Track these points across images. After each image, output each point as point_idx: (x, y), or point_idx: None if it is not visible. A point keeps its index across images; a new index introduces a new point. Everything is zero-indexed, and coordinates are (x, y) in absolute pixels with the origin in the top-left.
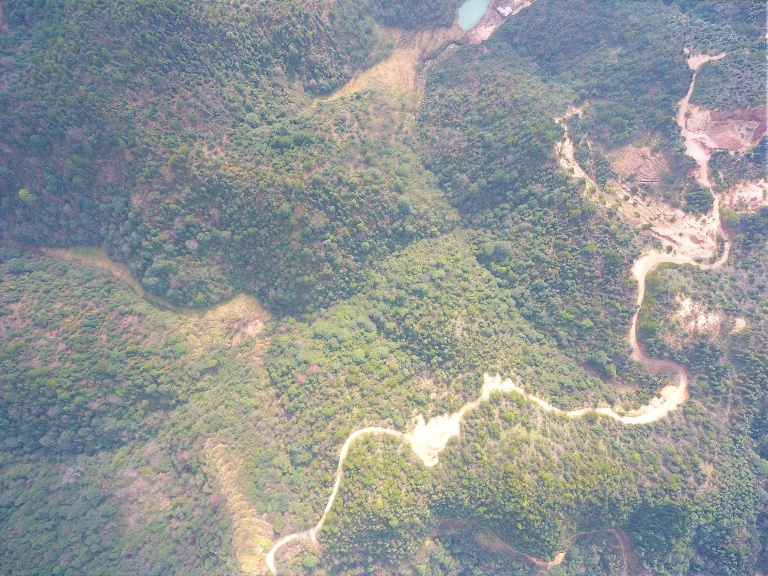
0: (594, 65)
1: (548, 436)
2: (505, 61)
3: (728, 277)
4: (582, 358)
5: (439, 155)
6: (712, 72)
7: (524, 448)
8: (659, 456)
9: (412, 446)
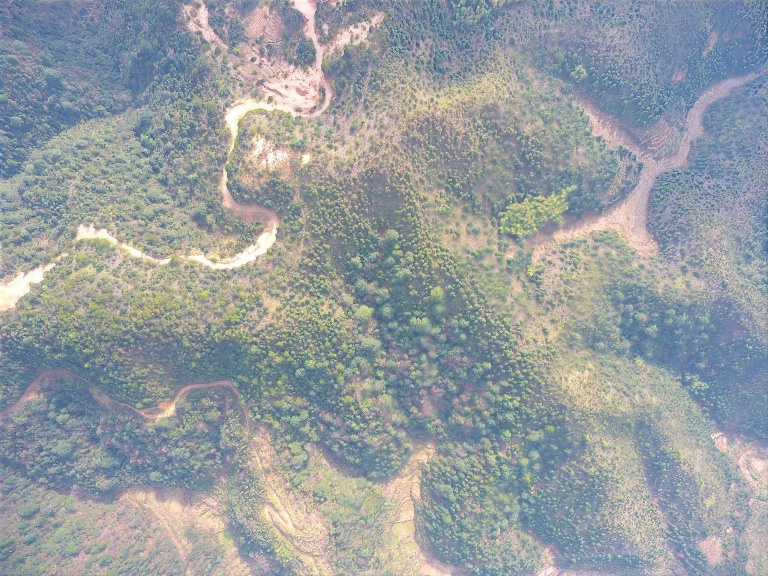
0: None
1: (119, 276)
2: None
3: (317, 122)
4: (192, 212)
5: (111, 36)
6: None
7: (85, 285)
8: (227, 293)
9: None
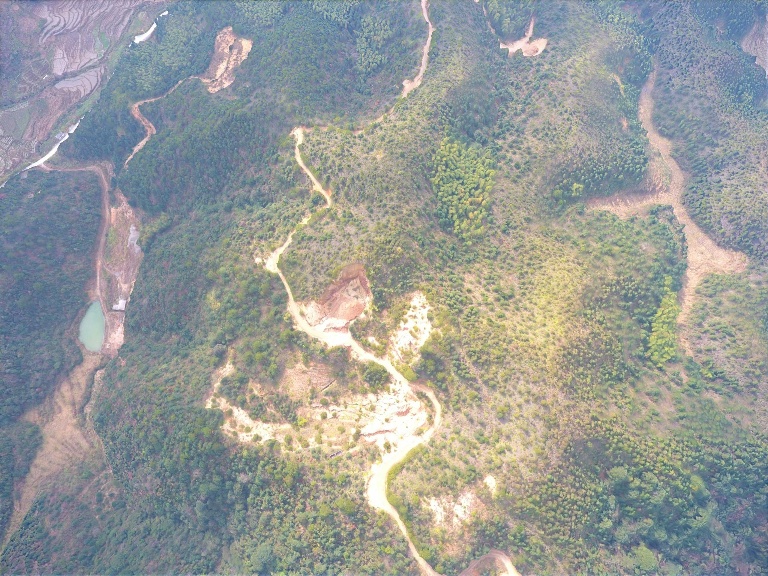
0: (209, 316)
1: None
2: (138, 369)
3: (452, 431)
4: None
5: (151, 500)
6: (288, 266)
7: None
8: None
9: None
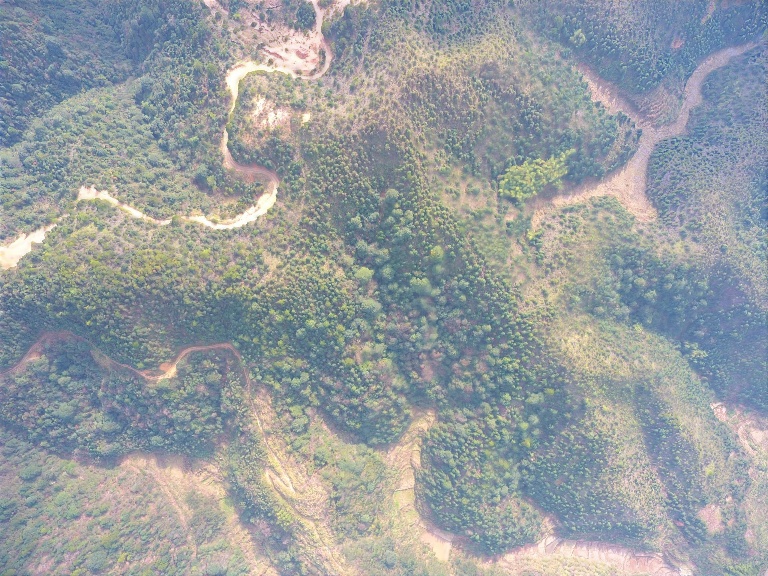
0: None
1: (120, 235)
2: None
3: None
4: (193, 175)
5: (112, 6)
6: None
7: (86, 243)
8: (228, 251)
9: (2, 256)
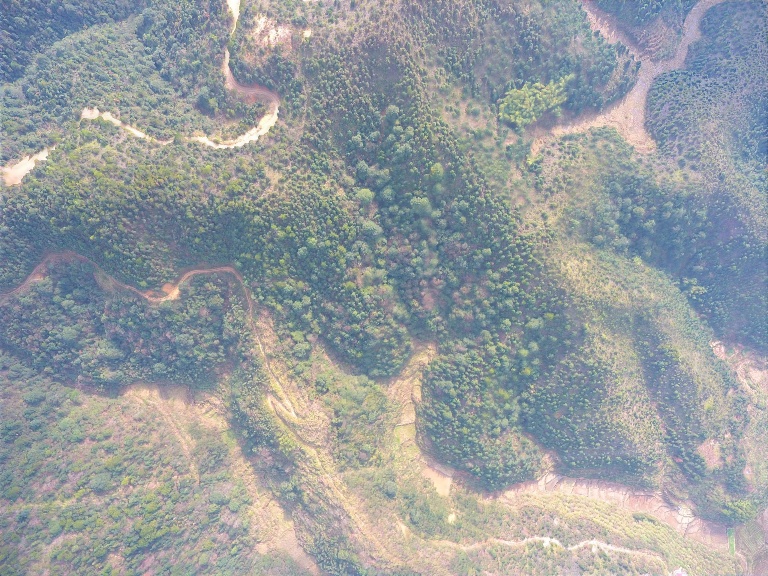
0: None
1: (123, 151)
2: None
3: None
4: (195, 100)
5: None
6: None
7: (90, 157)
8: (230, 166)
9: (6, 175)
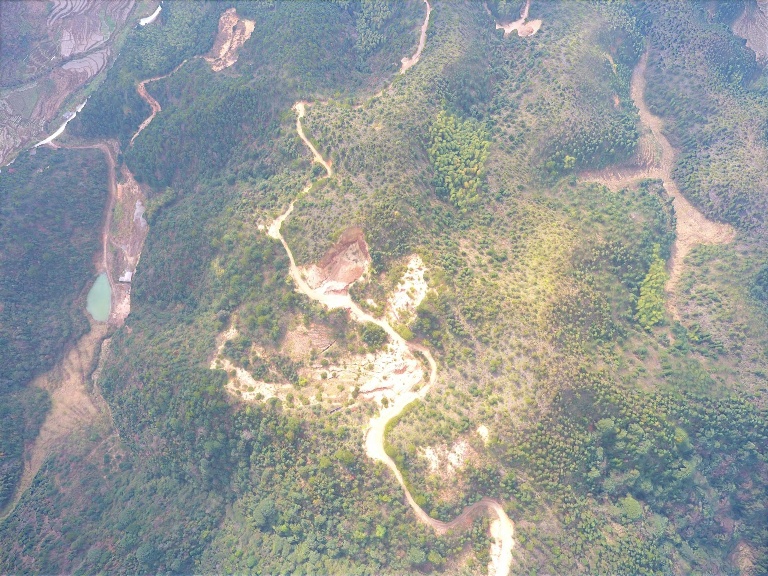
0: (213, 283)
1: None
2: (144, 335)
3: (447, 386)
4: (406, 564)
5: (157, 460)
6: (290, 232)
7: None
8: None
9: None
